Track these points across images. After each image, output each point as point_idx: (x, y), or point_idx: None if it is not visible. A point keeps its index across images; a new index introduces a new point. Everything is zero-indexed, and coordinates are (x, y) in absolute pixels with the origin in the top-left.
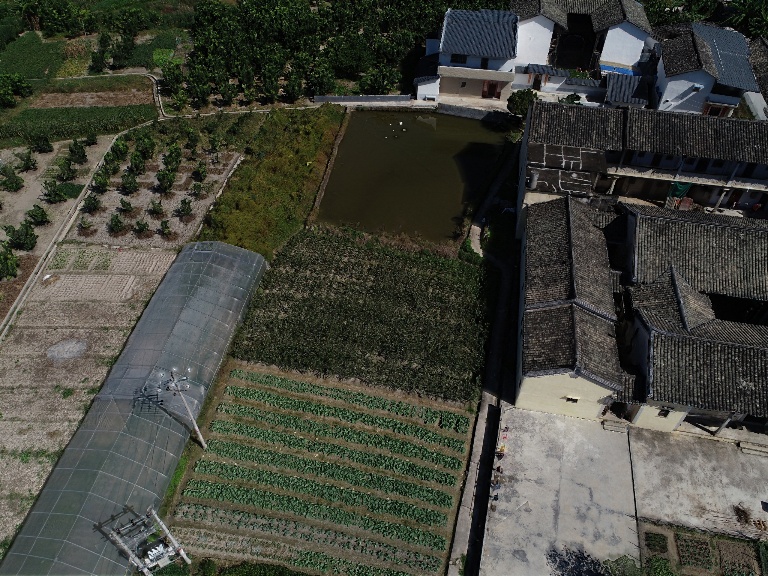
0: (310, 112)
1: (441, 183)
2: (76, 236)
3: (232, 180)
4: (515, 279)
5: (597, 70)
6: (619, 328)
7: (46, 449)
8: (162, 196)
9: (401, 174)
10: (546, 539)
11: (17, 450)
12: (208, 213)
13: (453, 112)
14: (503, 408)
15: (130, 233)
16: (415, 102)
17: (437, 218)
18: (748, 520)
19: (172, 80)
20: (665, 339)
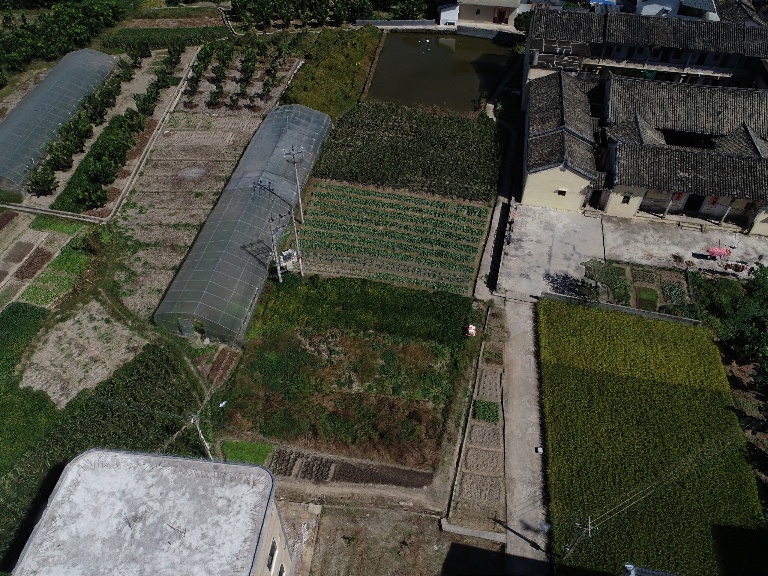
0: (354, 32)
1: (462, 79)
2: (183, 108)
3: (299, 73)
4: (521, 135)
5: (587, 4)
6: (597, 158)
7: (191, 223)
8: (244, 85)
9: (430, 73)
10: (543, 269)
11: (170, 223)
12: (282, 94)
13: (470, 33)
14: (513, 201)
15: (224, 107)
16: (438, 26)
17: (460, 100)
18: (681, 260)
19: (241, 6)
20: (627, 147)
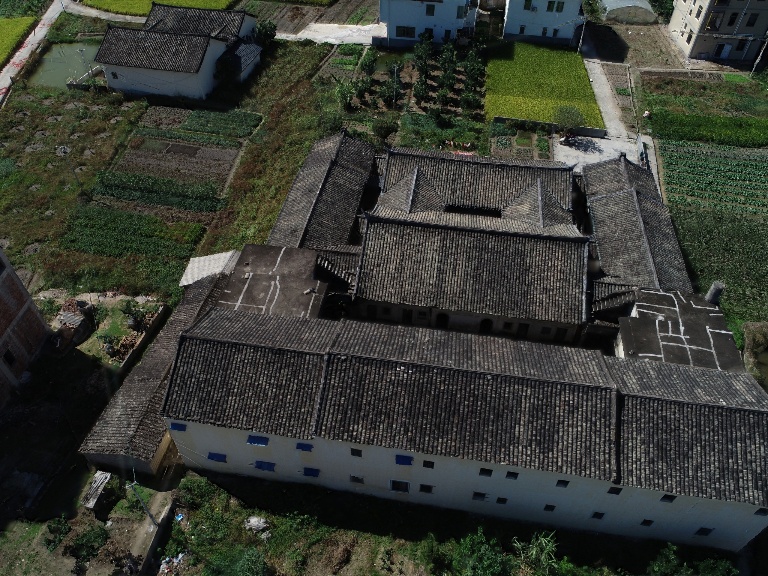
0: None
1: None
2: None
3: None
4: None
5: None
6: None
7: None
8: None
9: None
10: (605, 155)
11: None
12: None
13: None
14: None
15: None
16: None
17: None
18: None
19: None
20: None
